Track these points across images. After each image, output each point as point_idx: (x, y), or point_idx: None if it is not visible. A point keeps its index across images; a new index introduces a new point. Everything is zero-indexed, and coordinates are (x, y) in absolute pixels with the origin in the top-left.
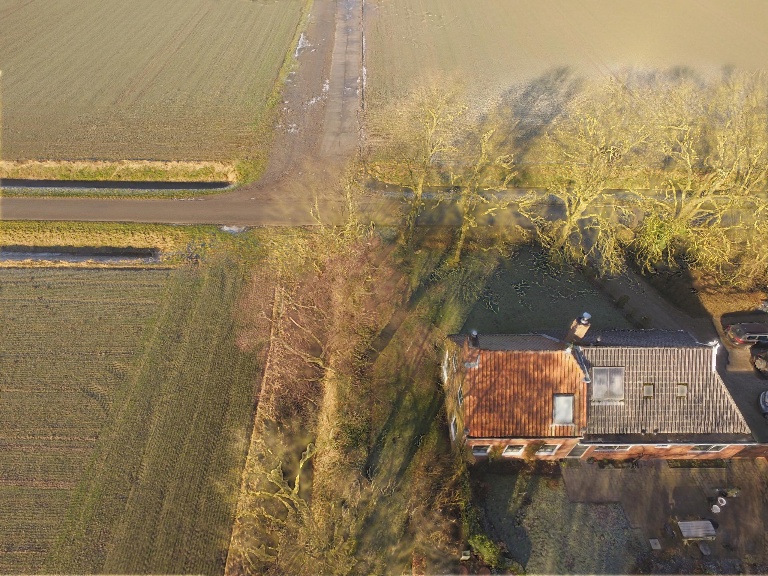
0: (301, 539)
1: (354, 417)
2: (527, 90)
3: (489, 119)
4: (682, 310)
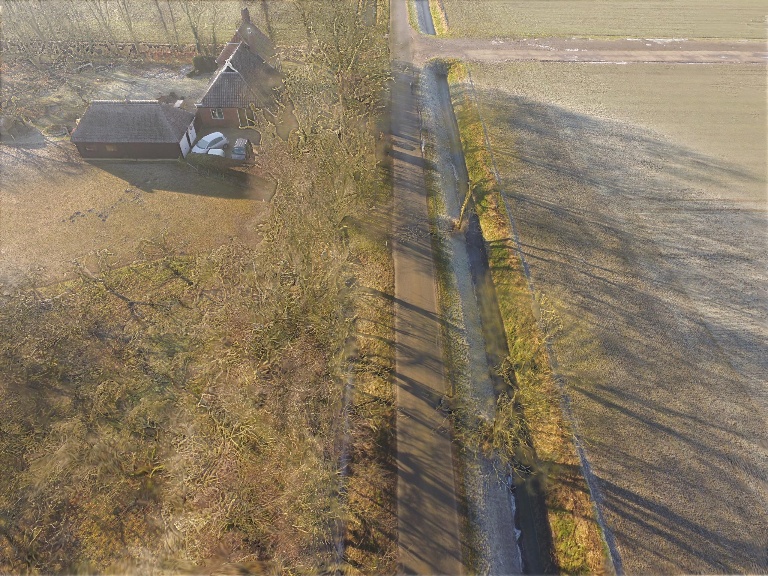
0: (197, 2)
1: None
2: (646, 135)
3: (554, 107)
4: None
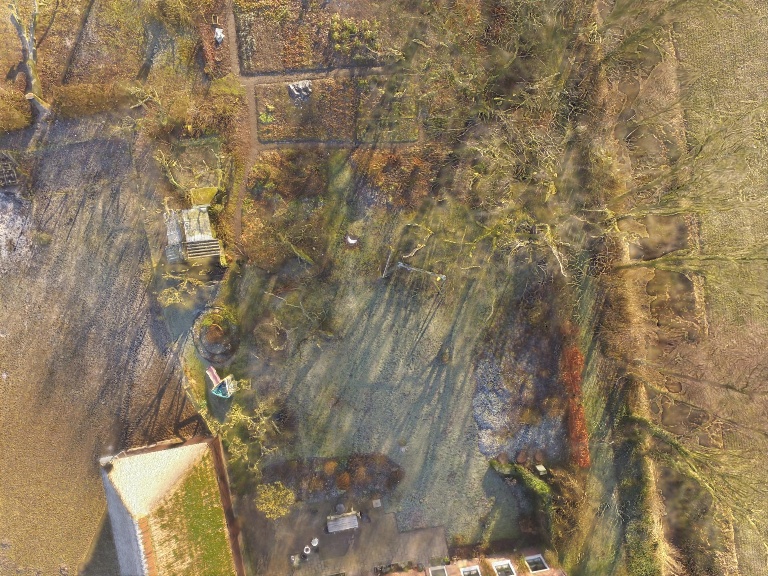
0: None
1: (644, 570)
2: None
3: None
4: None
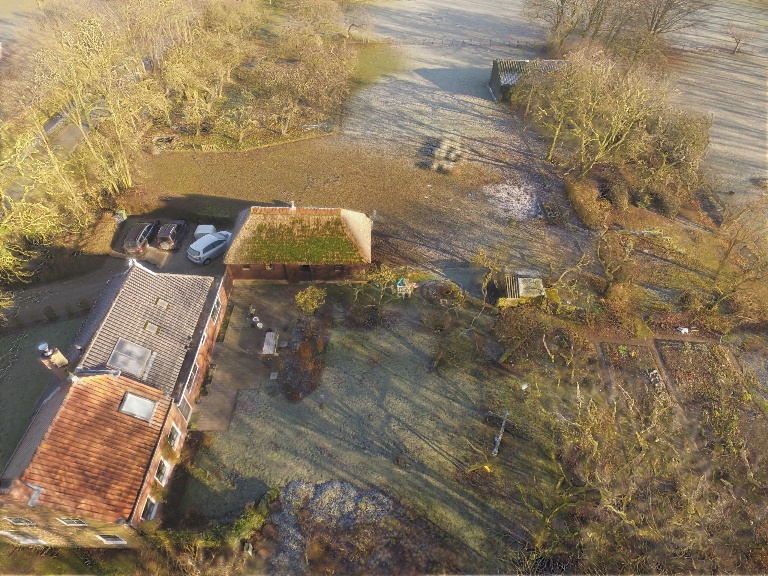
0: None
1: None
2: None
3: None
4: (89, 272)
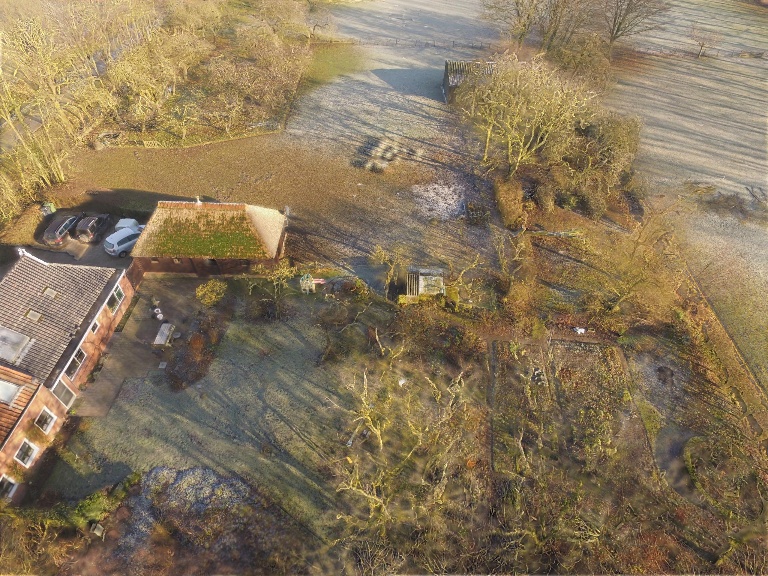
0: None
1: None
2: None
3: None
4: (8, 262)
